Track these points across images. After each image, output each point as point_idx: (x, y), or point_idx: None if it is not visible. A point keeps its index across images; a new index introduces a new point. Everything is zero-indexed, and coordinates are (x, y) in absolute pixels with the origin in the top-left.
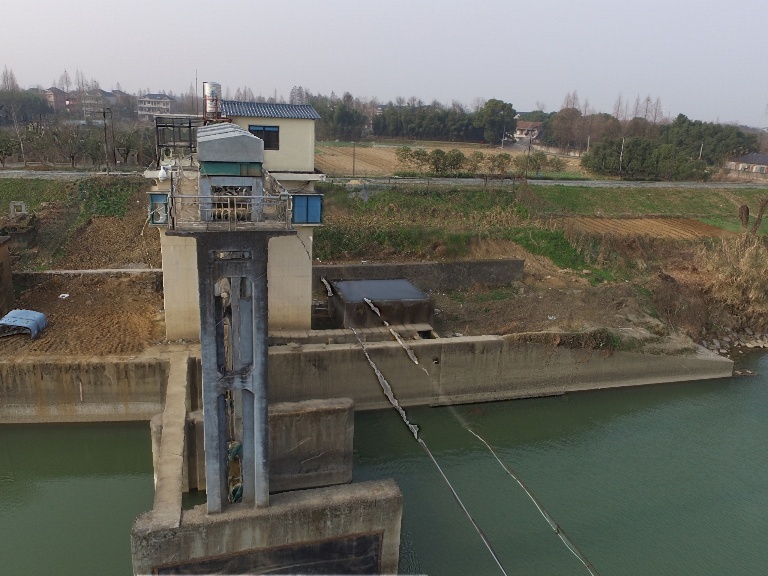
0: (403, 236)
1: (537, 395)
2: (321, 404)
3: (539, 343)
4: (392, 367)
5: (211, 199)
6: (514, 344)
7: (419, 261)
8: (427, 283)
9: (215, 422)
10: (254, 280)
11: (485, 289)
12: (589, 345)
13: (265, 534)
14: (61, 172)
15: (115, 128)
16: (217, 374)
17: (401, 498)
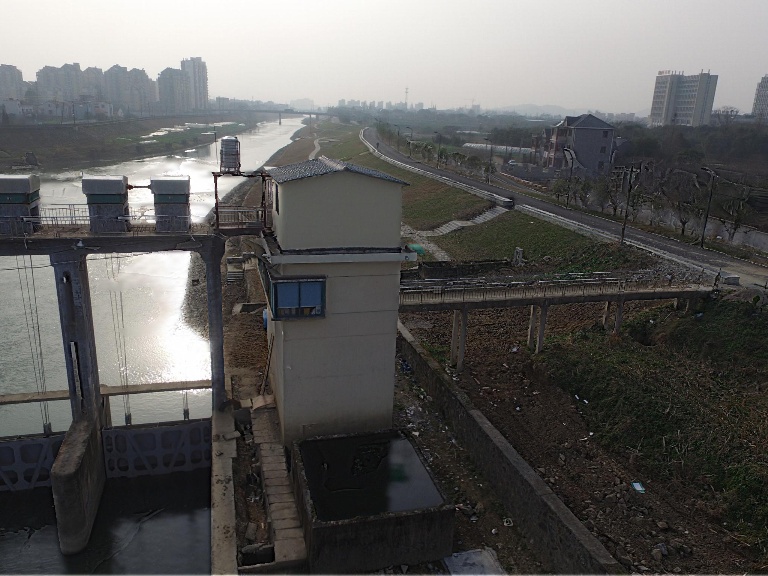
0: None
1: None
2: (69, 454)
3: None
4: None
5: None
6: None
7: (719, 570)
8: None
9: None
10: None
11: None
12: None
13: None
14: (604, 232)
15: (714, 194)
16: None
17: None
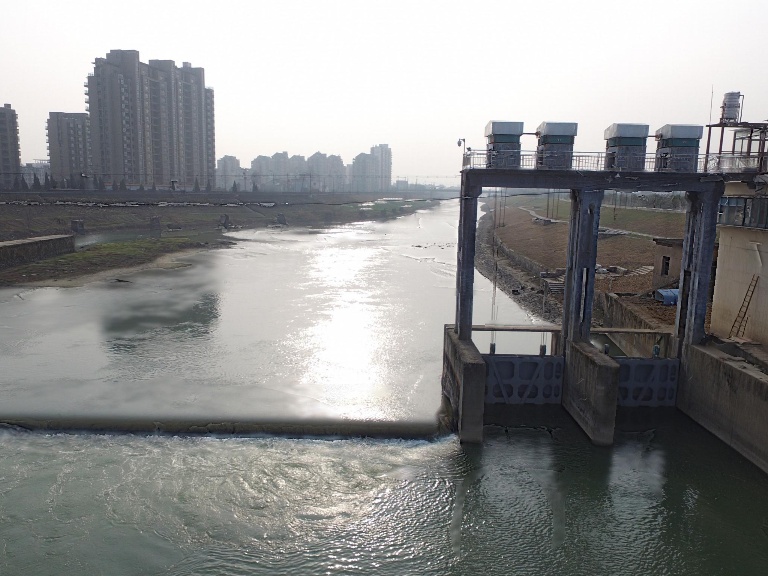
0: None
1: None
2: (600, 357)
3: None
4: None
5: (488, 157)
6: None
7: None
8: None
9: None
10: None
11: None
12: None
13: None
14: None
15: None
16: None
17: None
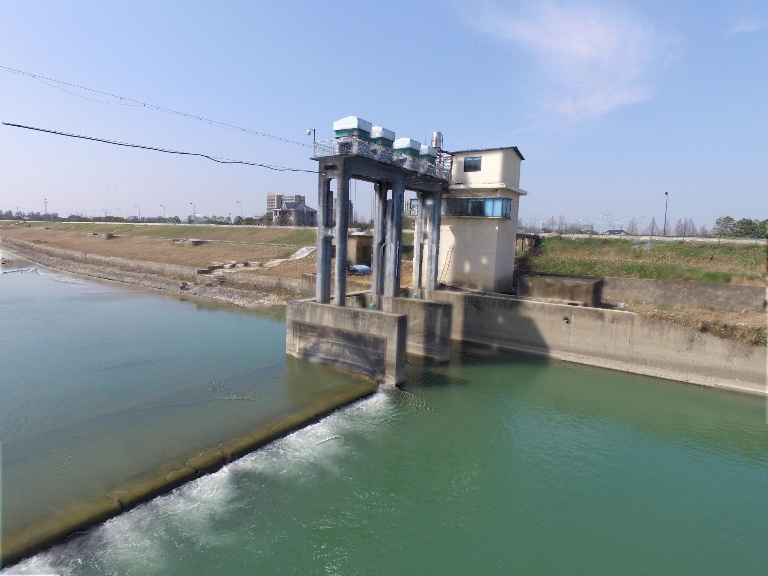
0: (654, 270)
1: (677, 379)
2: (432, 301)
3: (678, 325)
4: (529, 318)
5: (339, 149)
6: (646, 320)
7: None
8: (641, 296)
9: (321, 252)
10: (338, 179)
11: (705, 309)
12: (745, 338)
13: (333, 319)
14: None
15: None
16: (323, 227)
17: (397, 318)
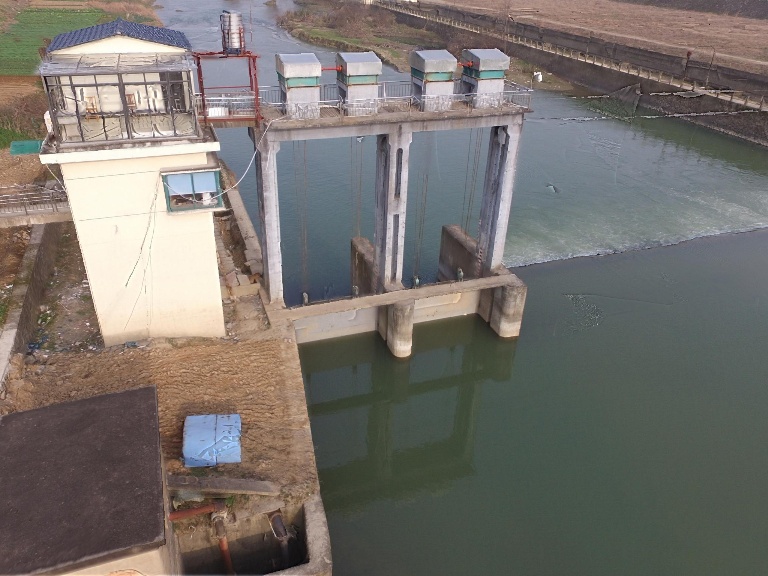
0: None
1: None
2: (365, 246)
3: None
4: None
5: None
6: None
7: None
8: None
9: None
10: None
11: None
12: None
13: None
14: None
15: None
16: None
17: None
